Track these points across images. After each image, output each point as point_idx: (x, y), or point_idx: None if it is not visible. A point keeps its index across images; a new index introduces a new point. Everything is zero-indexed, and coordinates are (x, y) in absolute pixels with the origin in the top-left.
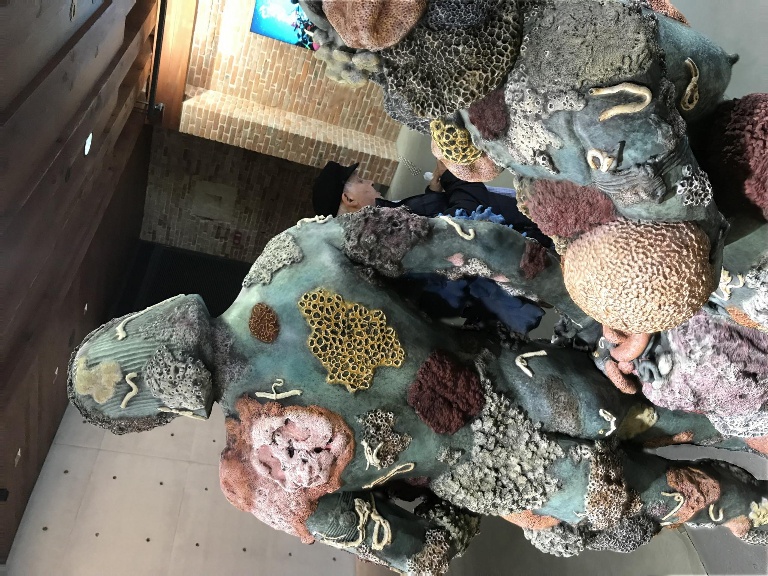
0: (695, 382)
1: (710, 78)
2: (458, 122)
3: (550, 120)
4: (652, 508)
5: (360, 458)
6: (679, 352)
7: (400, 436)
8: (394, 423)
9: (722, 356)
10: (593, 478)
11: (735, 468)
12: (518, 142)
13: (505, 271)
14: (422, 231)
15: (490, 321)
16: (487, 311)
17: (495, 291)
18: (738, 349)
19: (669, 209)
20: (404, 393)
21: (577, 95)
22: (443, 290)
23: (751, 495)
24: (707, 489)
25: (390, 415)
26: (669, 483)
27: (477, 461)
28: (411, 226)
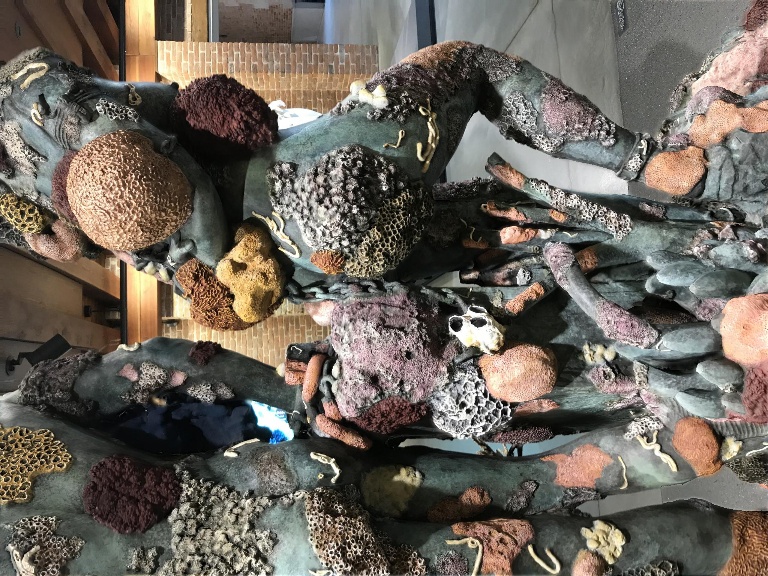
0: (358, 362)
1: (147, 89)
2: (8, 191)
3: (5, 113)
4: (443, 565)
5: (5, 568)
6: (337, 348)
7: (65, 539)
8: (57, 527)
9: (358, 321)
10: (310, 513)
11: (553, 509)
12: (14, 154)
13: (177, 365)
14: (89, 358)
15: (214, 449)
16: (214, 446)
17: (196, 407)
18: (371, 311)
19: (102, 126)
20: (80, 503)
21: (5, 85)
22: (145, 425)
23: (578, 523)
24: (513, 529)
25: (51, 518)
26: (455, 531)
27: (178, 554)
28: (79, 358)
